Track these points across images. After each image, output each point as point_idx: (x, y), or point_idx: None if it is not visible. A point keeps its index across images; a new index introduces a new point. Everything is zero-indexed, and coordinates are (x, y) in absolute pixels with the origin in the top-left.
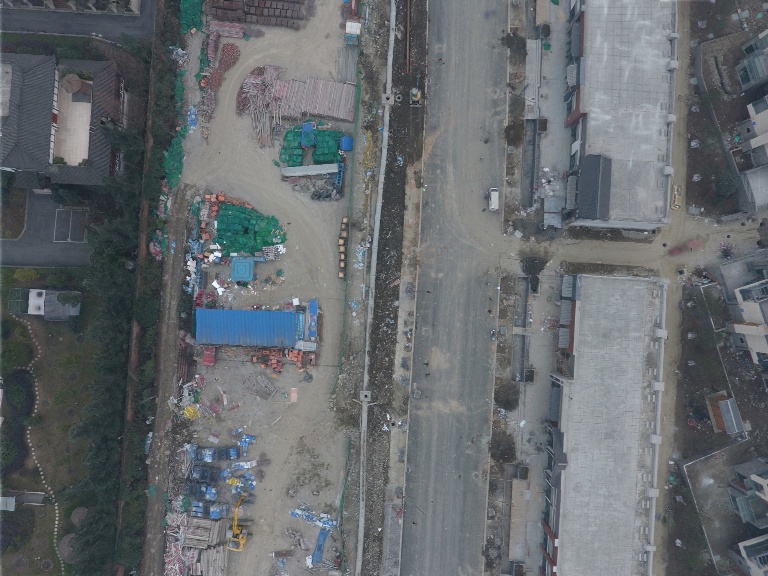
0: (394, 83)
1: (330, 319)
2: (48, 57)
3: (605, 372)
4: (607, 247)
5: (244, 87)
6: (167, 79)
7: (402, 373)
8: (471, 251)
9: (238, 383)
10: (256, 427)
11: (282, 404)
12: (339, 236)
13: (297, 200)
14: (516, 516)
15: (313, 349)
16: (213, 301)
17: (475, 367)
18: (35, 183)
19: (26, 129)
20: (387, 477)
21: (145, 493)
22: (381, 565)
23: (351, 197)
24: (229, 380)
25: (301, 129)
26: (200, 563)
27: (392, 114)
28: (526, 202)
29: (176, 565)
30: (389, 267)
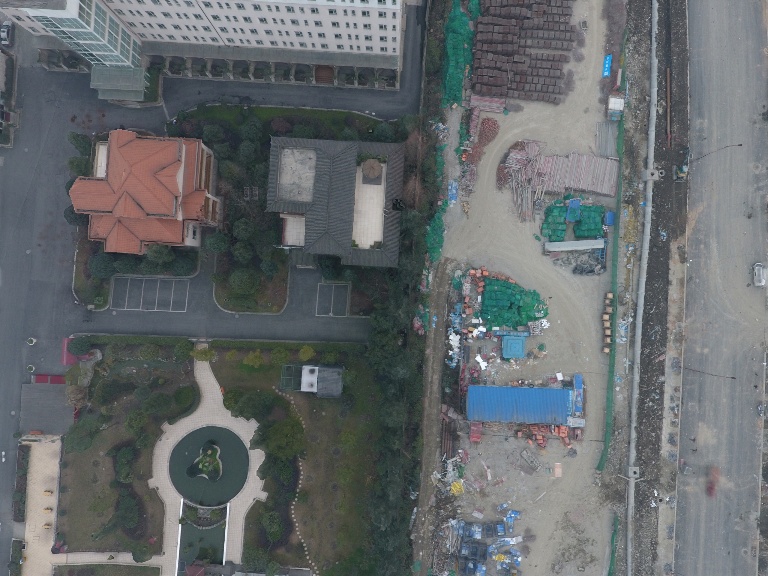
0: (655, 158)
1: (593, 394)
2: (353, 143)
3: None
4: None
5: (508, 162)
6: (432, 155)
7: (669, 449)
8: (736, 326)
9: (502, 458)
10: (520, 502)
11: (546, 479)
12: (604, 311)
13: (558, 274)
14: None
15: (582, 425)
16: (478, 376)
17: (742, 443)
18: (309, 261)
19: (334, 216)
20: (656, 554)
21: (410, 569)
22: None
23: (614, 272)
24: (493, 455)
25: (562, 203)
26: None
27: (655, 189)
28: None
29: None
30: (654, 342)
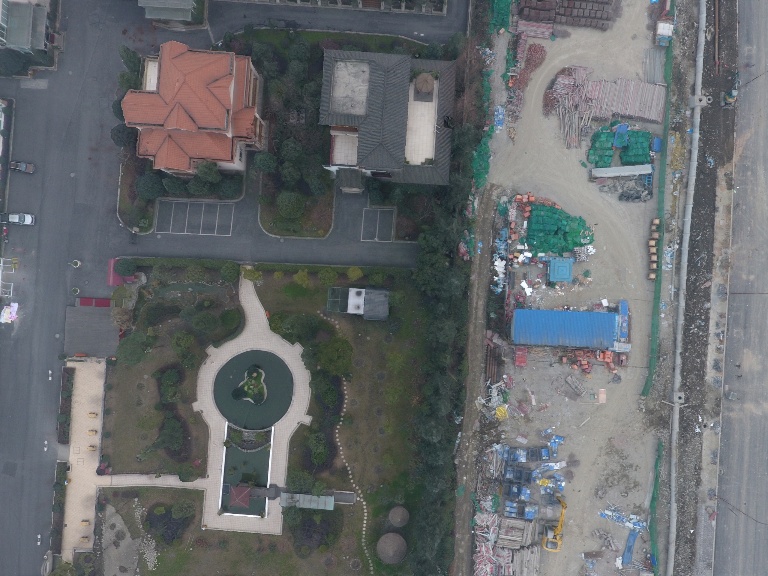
0: (703, 85)
1: (638, 320)
2: (406, 56)
3: None
4: None
5: (555, 87)
6: (479, 79)
7: (714, 375)
8: None
9: (546, 384)
10: (565, 428)
11: (591, 405)
12: (650, 237)
13: (604, 201)
14: None
15: (628, 350)
16: None
17: None
18: (357, 182)
19: (388, 128)
20: (700, 479)
21: None
22: (694, 567)
23: (660, 198)
24: (537, 381)
25: (609, 130)
26: (513, 563)
27: (702, 116)
28: None
29: (487, 565)
30: (699, 269)
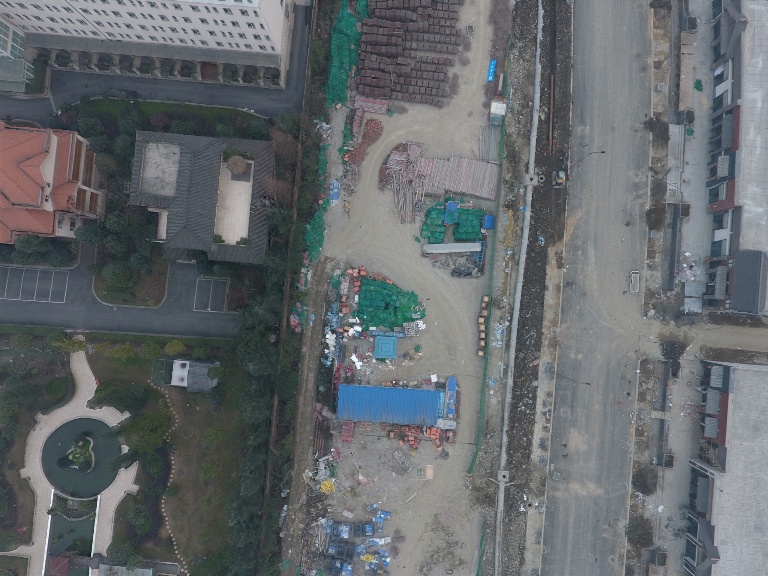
0: (536, 163)
1: (467, 396)
2: (216, 139)
3: (755, 465)
4: (747, 333)
5: (389, 163)
6: (313, 154)
7: (540, 454)
8: (611, 333)
9: (374, 458)
10: (391, 503)
11: (418, 481)
12: (479, 314)
13: (437, 276)
14: None
15: (453, 428)
16: (352, 376)
17: (613, 450)
18: (183, 255)
19: (194, 211)
20: (523, 558)
21: (278, 567)
22: None
23: (491, 275)
24: (365, 455)
25: (443, 206)
26: None
27: (534, 194)
28: (665, 285)
29: None
30: (528, 346)
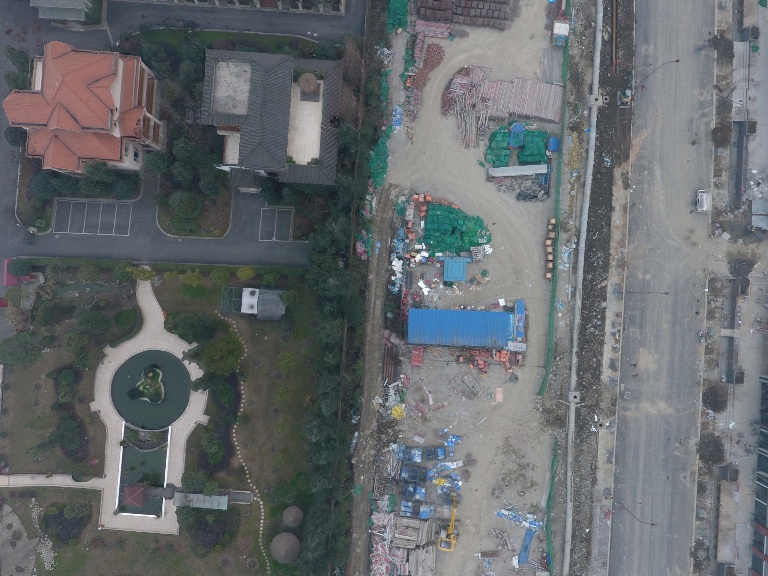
0: (600, 84)
1: (535, 320)
2: (287, 56)
3: None
4: None
5: (452, 87)
6: (375, 79)
7: (610, 374)
8: (678, 253)
9: (443, 383)
10: (462, 427)
11: (488, 404)
12: (547, 237)
13: (502, 200)
14: (725, 518)
15: (523, 350)
16: (420, 301)
17: (683, 368)
18: (250, 182)
19: (268, 128)
20: (595, 478)
21: (351, 492)
22: (589, 566)
23: (557, 198)
24: (434, 380)
25: (506, 130)
26: (408, 563)
27: (599, 115)
28: (731, 204)
29: (383, 565)
30: (596, 268)
